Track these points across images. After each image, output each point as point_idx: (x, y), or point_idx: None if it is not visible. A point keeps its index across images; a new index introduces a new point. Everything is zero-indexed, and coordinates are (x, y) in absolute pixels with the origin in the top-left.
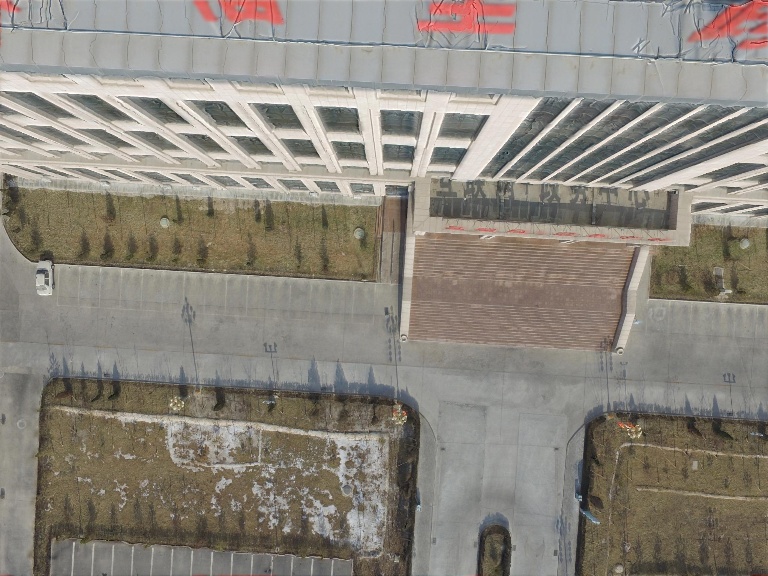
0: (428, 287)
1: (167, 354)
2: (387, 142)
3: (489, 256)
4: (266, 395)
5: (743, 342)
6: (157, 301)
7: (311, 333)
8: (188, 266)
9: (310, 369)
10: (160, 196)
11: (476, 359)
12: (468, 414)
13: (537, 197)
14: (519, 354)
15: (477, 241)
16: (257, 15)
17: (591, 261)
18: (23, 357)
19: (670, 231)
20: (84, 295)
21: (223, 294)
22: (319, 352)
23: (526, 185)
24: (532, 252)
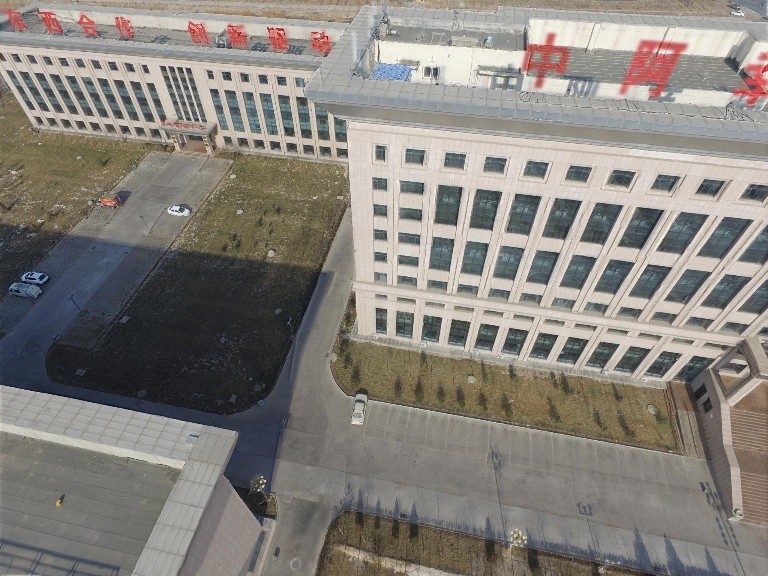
0: (748, 460)
1: (471, 501)
2: None
3: None
4: (592, 565)
5: None
6: (462, 445)
7: (627, 499)
8: (492, 417)
9: (634, 541)
10: (467, 360)
11: None
12: None
13: None
14: None
15: None
16: None
17: None
18: (317, 483)
19: None
20: (391, 430)
21: (528, 447)
22: (640, 522)
23: None
24: None
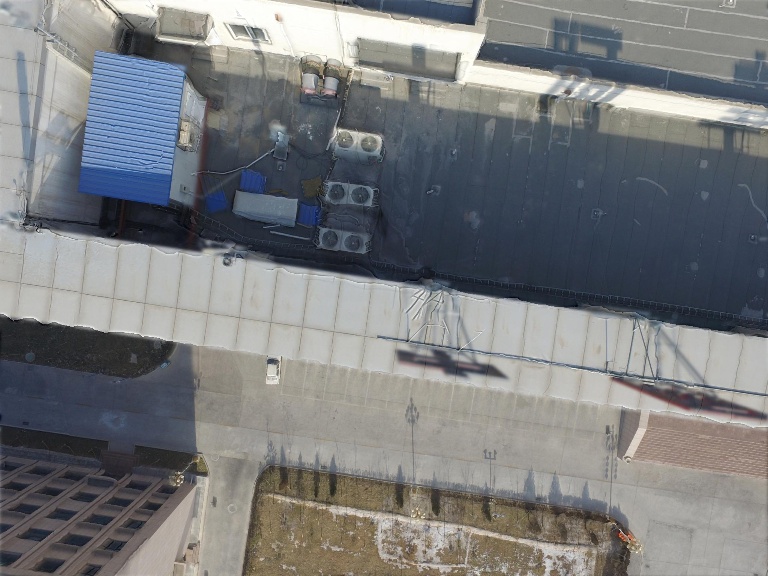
0: (660, 415)
1: (386, 452)
2: None
3: None
4: (484, 502)
5: None
6: (382, 399)
7: (532, 444)
8: None
9: (527, 479)
10: None
11: (689, 483)
12: (675, 535)
13: None
14: (731, 481)
15: None
16: None
17: None
18: (241, 442)
19: None
20: (309, 386)
21: (449, 398)
22: (537, 463)
23: None
24: None
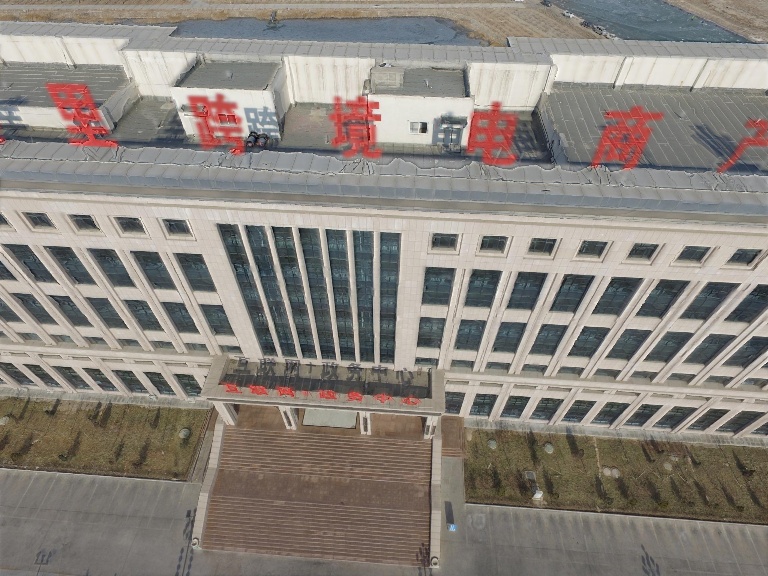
0: (233, 481)
1: None
2: (163, 299)
3: (295, 447)
4: None
5: (575, 557)
6: None
7: (97, 540)
8: (2, 463)
9: None
10: (14, 398)
11: None
12: None
13: (318, 375)
14: (326, 570)
15: (284, 431)
16: (6, 149)
17: (393, 454)
18: None
19: (427, 399)
20: None
21: (22, 493)
22: (97, 565)
23: (310, 366)
24: (336, 443)
